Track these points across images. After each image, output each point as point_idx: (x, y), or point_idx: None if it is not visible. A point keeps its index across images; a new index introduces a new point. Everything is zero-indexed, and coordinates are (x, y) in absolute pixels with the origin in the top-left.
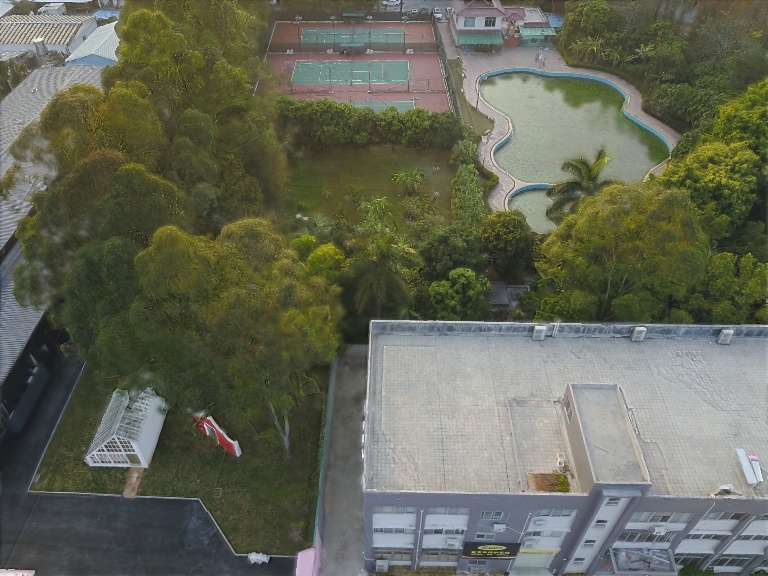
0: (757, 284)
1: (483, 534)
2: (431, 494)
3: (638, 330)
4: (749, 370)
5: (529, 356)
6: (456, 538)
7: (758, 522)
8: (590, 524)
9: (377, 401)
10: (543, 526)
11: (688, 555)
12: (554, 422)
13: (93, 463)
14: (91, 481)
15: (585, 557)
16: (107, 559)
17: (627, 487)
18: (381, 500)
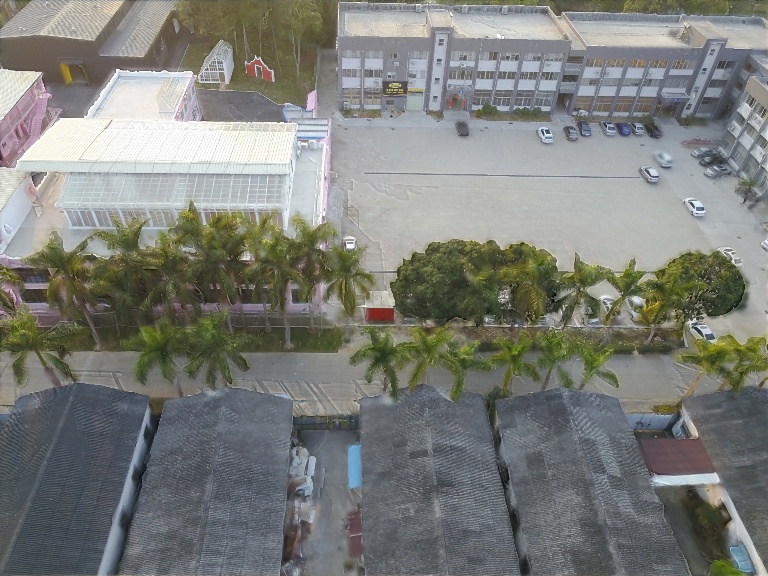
0: (528, 1)
1: (390, 75)
2: (366, 37)
3: (464, 6)
4: (513, 20)
5: (413, 16)
6: (379, 80)
7: (505, 62)
8: (434, 58)
9: (343, 25)
10: (415, 66)
11: (483, 96)
12: (421, 30)
13: (201, 81)
14: (201, 86)
15: (437, 95)
16: (217, 105)
17: (445, 29)
18: (345, 43)
